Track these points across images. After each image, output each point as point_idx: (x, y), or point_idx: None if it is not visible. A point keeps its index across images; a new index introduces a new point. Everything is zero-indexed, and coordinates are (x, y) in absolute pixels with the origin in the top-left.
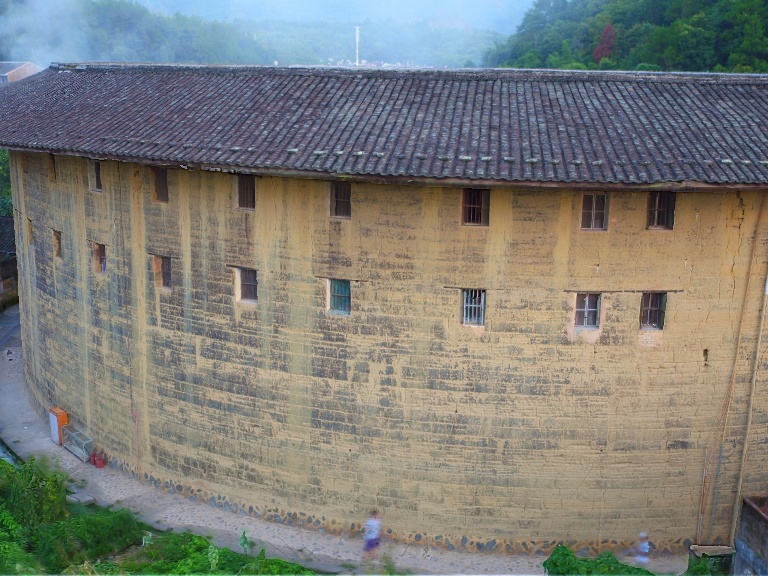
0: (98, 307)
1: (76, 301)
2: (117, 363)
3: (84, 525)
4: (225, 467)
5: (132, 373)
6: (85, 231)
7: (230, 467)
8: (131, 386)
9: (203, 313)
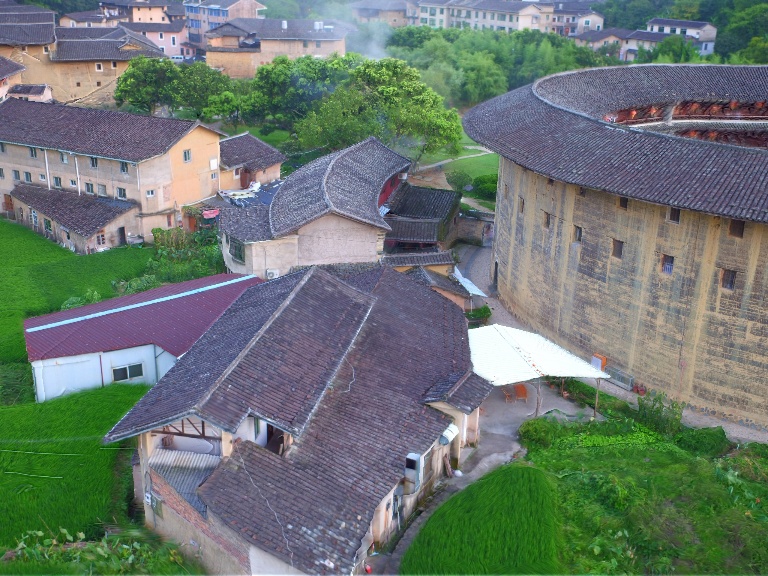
0: (658, 294)
1: (633, 288)
2: (670, 331)
3: (706, 435)
4: (756, 402)
5: (684, 339)
6: (655, 246)
7: (761, 402)
8: (682, 347)
9: (758, 308)
